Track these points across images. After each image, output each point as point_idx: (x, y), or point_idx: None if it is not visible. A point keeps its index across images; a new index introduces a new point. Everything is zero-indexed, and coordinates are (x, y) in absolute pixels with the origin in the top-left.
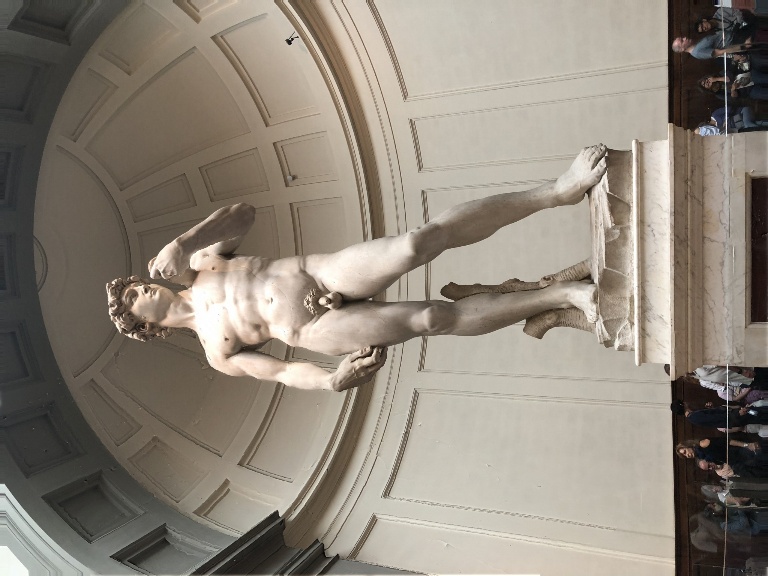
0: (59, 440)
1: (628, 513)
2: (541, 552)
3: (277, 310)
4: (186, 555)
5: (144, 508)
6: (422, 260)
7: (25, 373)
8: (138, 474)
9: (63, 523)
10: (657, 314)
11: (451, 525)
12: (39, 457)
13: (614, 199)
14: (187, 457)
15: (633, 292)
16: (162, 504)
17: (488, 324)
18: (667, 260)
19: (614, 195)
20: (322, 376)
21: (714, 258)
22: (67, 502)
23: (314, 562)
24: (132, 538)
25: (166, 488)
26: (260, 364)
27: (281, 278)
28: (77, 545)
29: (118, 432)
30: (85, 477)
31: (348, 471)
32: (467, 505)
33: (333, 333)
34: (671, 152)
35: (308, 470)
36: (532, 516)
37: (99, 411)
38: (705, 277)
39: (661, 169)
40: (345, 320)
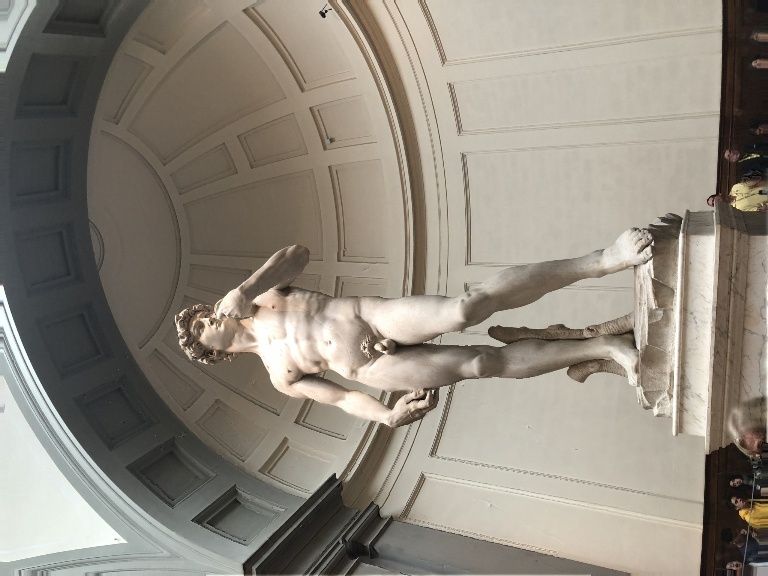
0: (134, 411)
1: (661, 478)
2: (578, 514)
3: (336, 353)
4: (256, 514)
5: (215, 471)
6: (472, 324)
7: (96, 351)
8: (206, 436)
9: (147, 491)
10: (695, 392)
11: (494, 486)
12: (118, 429)
13: (659, 284)
14: (248, 417)
15: (673, 368)
16: (230, 466)
17: (534, 372)
18: (707, 346)
19: (659, 281)
20: (380, 413)
21: (753, 348)
22: (148, 469)
23: (371, 525)
24: (208, 501)
25: (232, 448)
26: (321, 393)
27: (338, 323)
28: (162, 511)
29: (184, 397)
30: (160, 445)
31: (397, 430)
32: (509, 466)
33: (389, 377)
34: (717, 252)
35: (359, 428)
36: (570, 479)
37: (165, 378)
38: (743, 365)
39: (706, 263)
40: (400, 366)
